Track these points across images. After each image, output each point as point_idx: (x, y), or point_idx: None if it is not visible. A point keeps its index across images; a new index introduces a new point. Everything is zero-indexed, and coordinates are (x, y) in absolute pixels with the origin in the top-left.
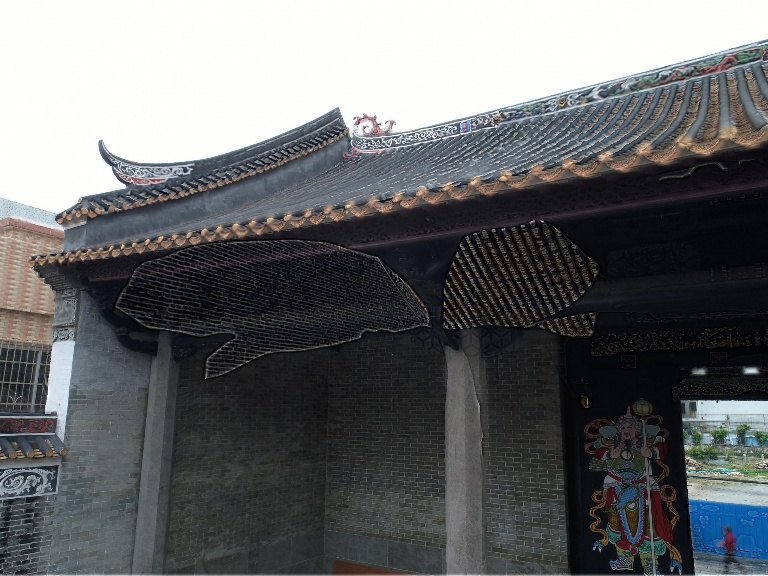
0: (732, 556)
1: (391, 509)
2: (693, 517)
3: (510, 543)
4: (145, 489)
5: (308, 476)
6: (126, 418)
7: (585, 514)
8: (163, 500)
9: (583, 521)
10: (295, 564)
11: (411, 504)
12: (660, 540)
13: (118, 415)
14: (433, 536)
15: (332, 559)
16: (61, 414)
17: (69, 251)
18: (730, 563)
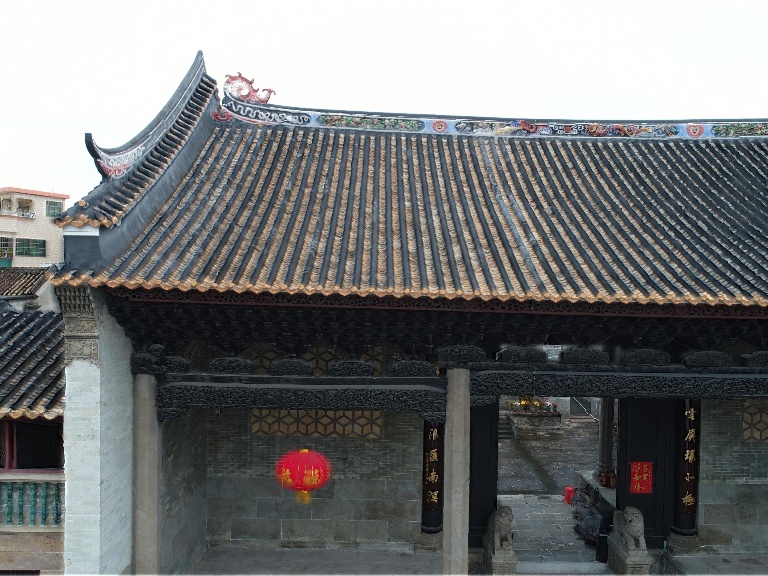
0: None
1: None
2: None
3: None
4: None
5: None
6: None
7: None
8: None
9: None
10: None
11: None
12: None
13: None
14: None
15: None
16: None
17: None
18: None
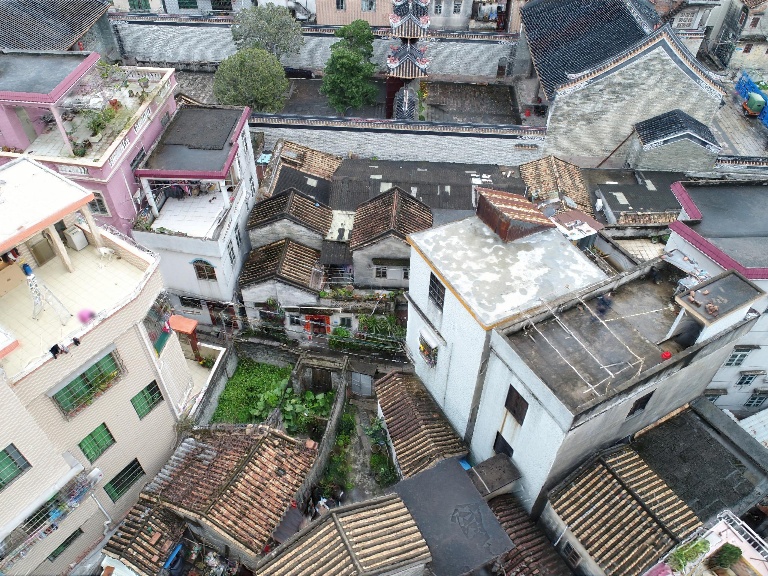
0: (765, 127)
1: None
2: (767, 108)
3: None
4: None
5: None
6: None
7: None
8: None
9: None
10: None
11: None
12: None
13: None
14: None
15: None
16: None
17: (523, 8)
18: (751, 127)
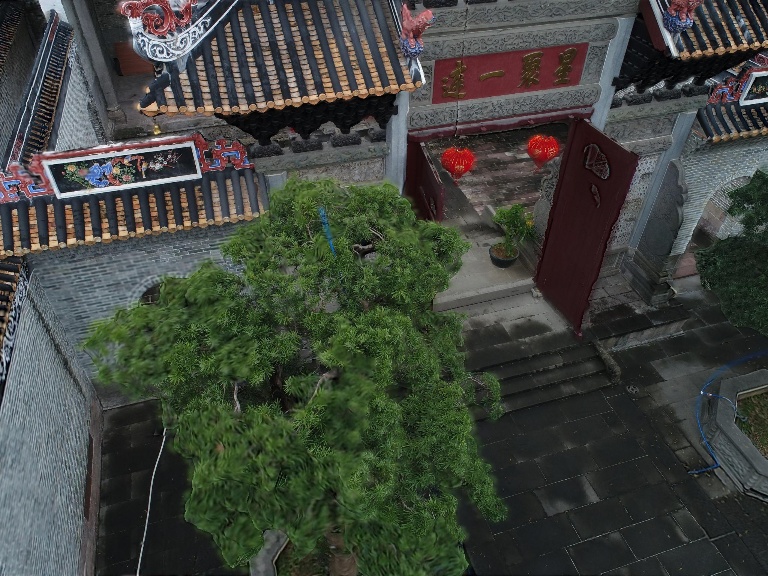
0: None
1: None
2: None
3: None
4: (89, 34)
5: (90, 2)
6: (68, 2)
7: None
8: (97, 37)
9: None
10: (104, 51)
11: None
12: None
13: (67, 2)
14: None
15: (112, 44)
16: (59, 10)
17: None
18: None
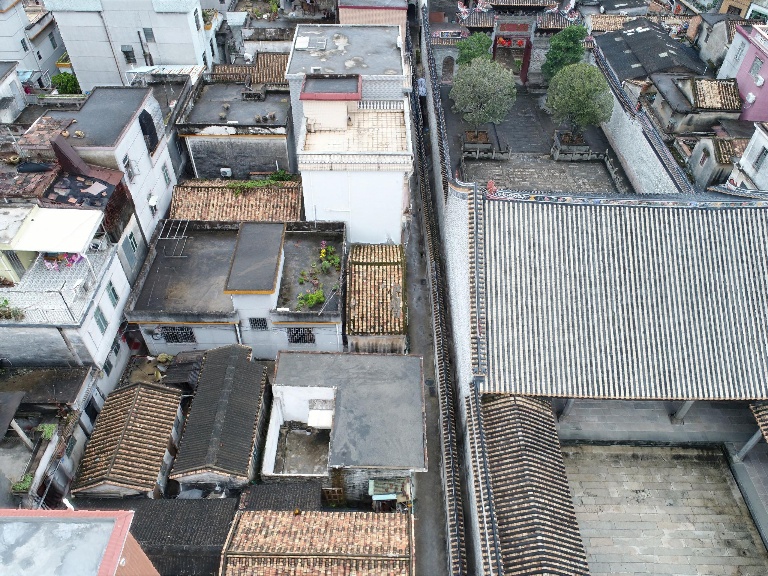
0: None
1: (437, 3)
2: None
3: (456, 6)
4: None
5: None
6: None
7: (467, 1)
8: None
9: (467, 2)
10: None
11: (441, 2)
12: (475, 3)
13: None
14: (444, 6)
15: None
16: None
17: None
18: None
